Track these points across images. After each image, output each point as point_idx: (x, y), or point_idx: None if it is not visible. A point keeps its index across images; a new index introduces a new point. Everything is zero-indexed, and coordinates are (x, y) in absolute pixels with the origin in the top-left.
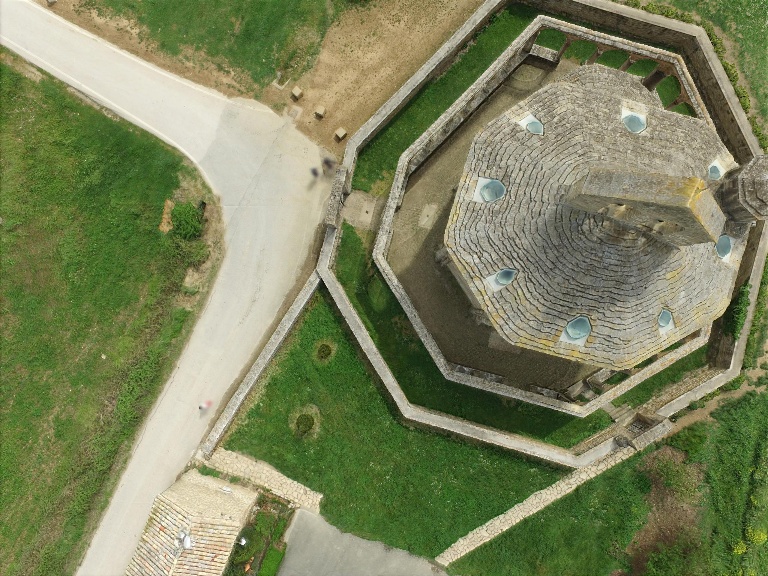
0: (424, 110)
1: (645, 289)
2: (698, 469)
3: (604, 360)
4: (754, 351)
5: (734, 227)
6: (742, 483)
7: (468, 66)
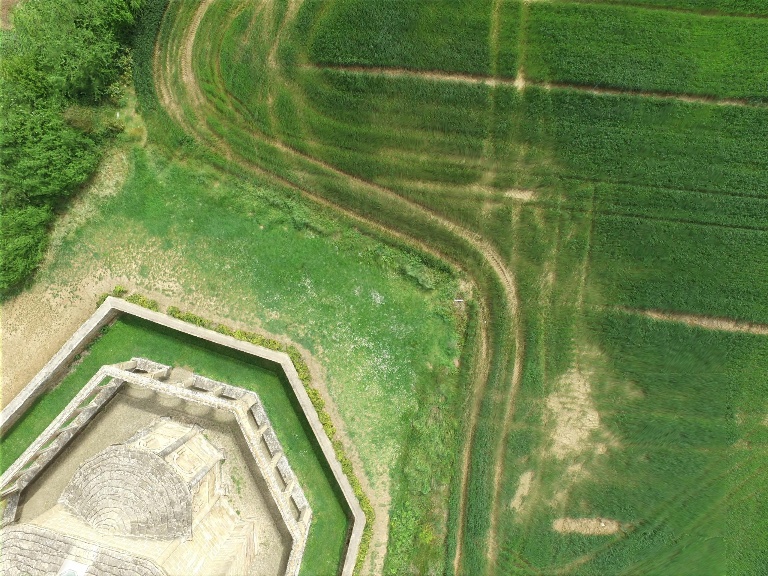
0: (41, 420)
1: None
2: None
3: None
4: None
5: None
6: None
7: (84, 375)
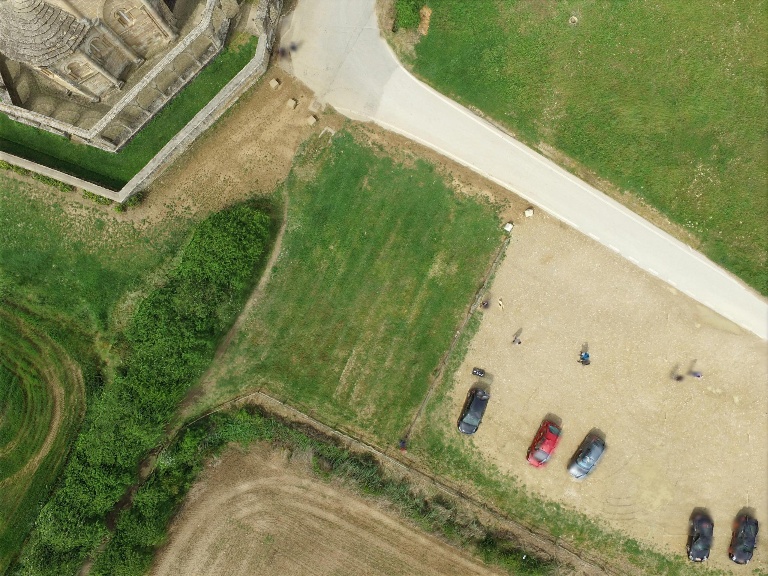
0: (204, 103)
1: None
2: None
3: None
4: None
5: None
6: None
7: (166, 140)
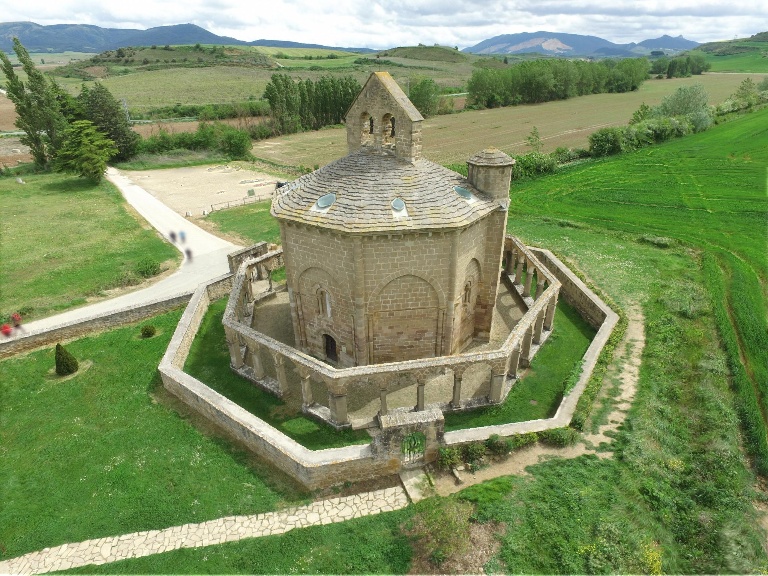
0: None
1: (382, 179)
2: (491, 534)
3: (338, 222)
4: (594, 418)
5: (478, 194)
6: (565, 570)
7: None
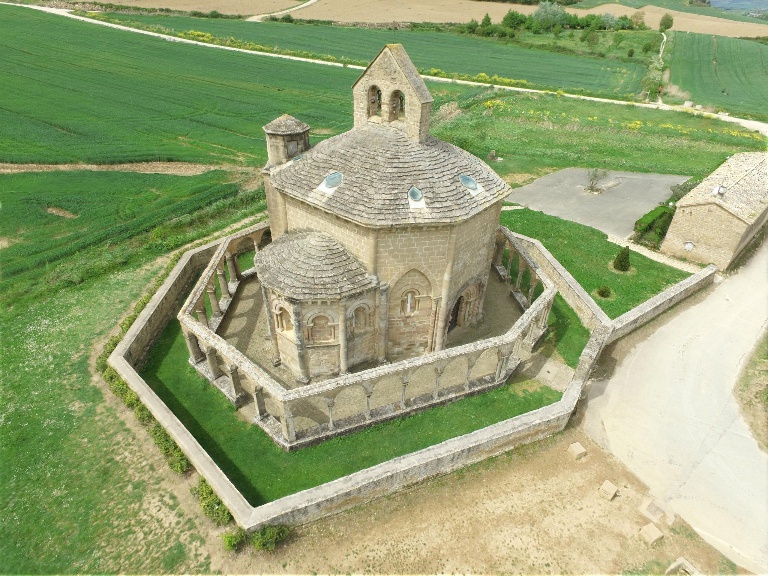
0: (453, 436)
1: None
2: None
3: None
4: None
5: None
6: None
7: (372, 463)
